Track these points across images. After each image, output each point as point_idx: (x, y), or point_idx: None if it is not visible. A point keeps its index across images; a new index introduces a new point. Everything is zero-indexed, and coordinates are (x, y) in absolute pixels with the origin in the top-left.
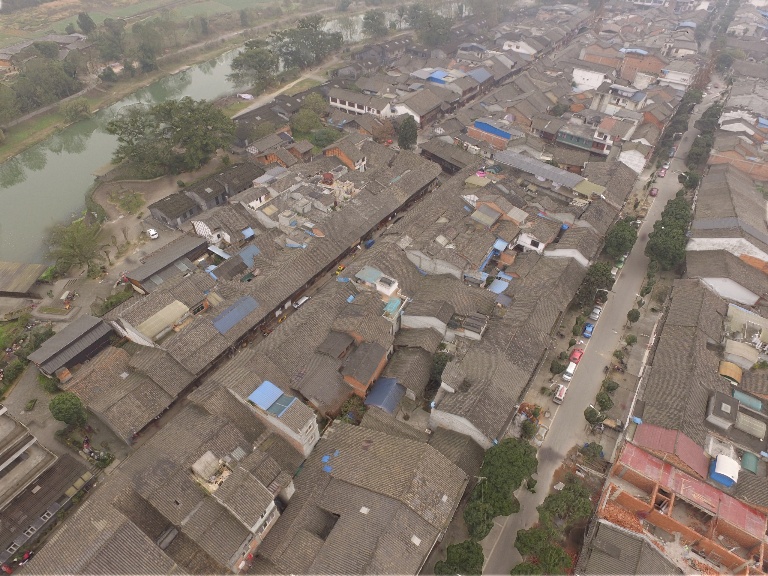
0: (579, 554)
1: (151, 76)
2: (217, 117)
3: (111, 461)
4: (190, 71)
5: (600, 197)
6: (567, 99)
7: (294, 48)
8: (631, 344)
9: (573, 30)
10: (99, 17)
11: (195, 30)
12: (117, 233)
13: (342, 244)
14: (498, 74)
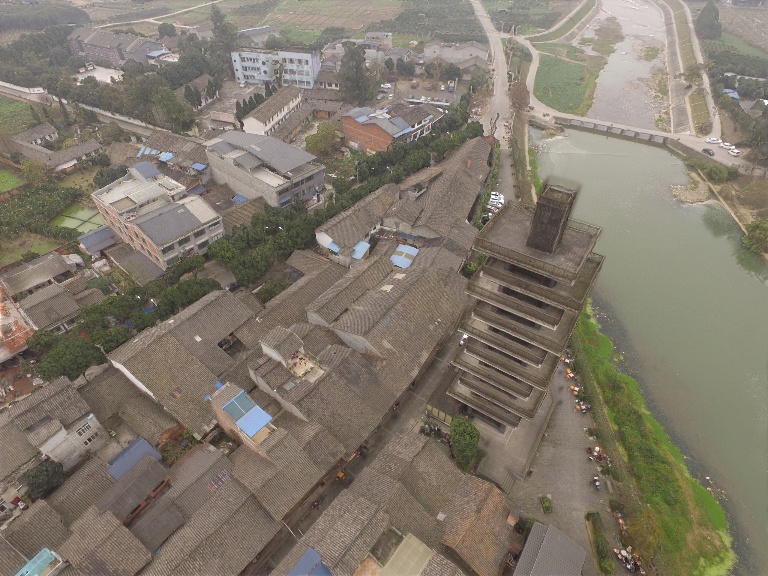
0: None
1: None
2: None
3: None
4: None
5: None
6: None
7: None
8: None
9: None
10: None
11: None
12: None
13: None
14: None
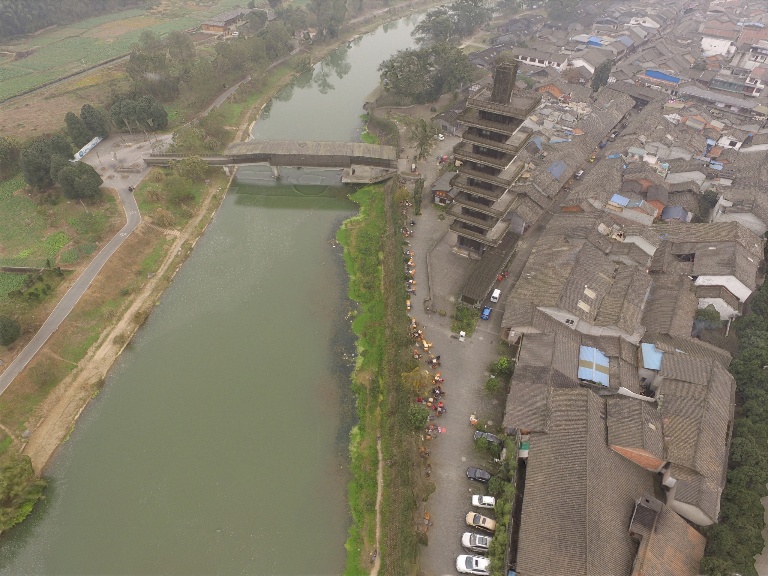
0: None
1: (335, 42)
2: None
3: None
4: None
5: None
6: (701, 61)
7: (457, 20)
8: None
9: (680, 11)
10: None
11: (354, 7)
12: None
13: (596, 139)
14: (636, 42)
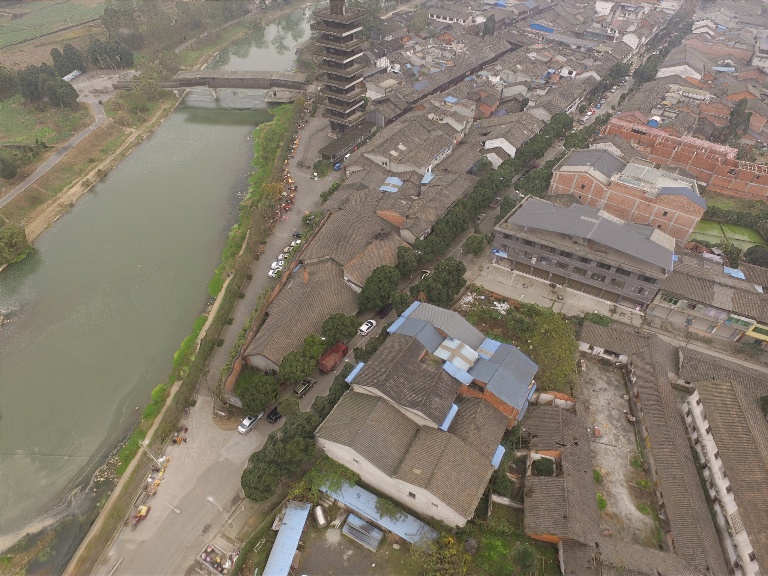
0: None
1: (289, 8)
2: (376, 11)
3: (379, 131)
4: None
5: (609, 52)
6: (591, 20)
7: None
8: (620, 104)
9: None
10: None
11: None
12: None
13: (463, 69)
14: (542, 6)
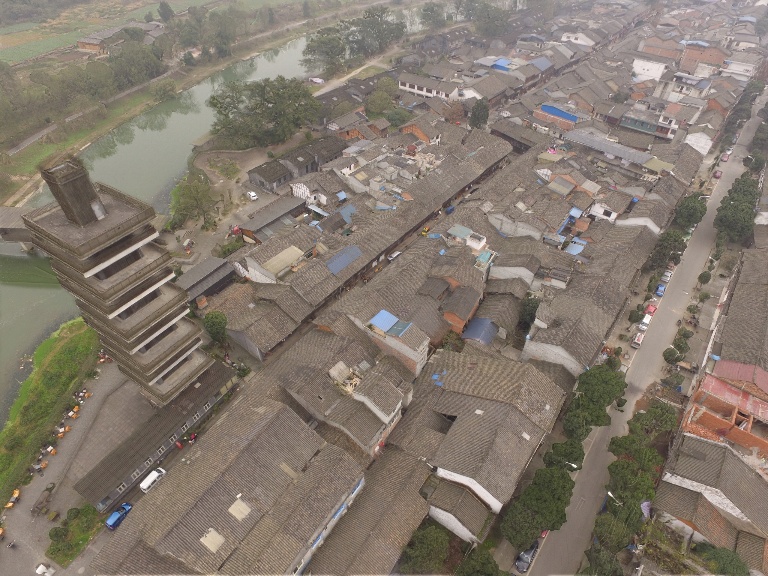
0: (665, 462)
1: (225, 61)
2: (307, 94)
3: (248, 372)
4: (256, 58)
5: (669, 173)
6: (627, 88)
7: (360, 37)
8: (704, 301)
9: (629, 24)
10: None
11: (263, 20)
12: None
13: (429, 207)
14: (558, 63)
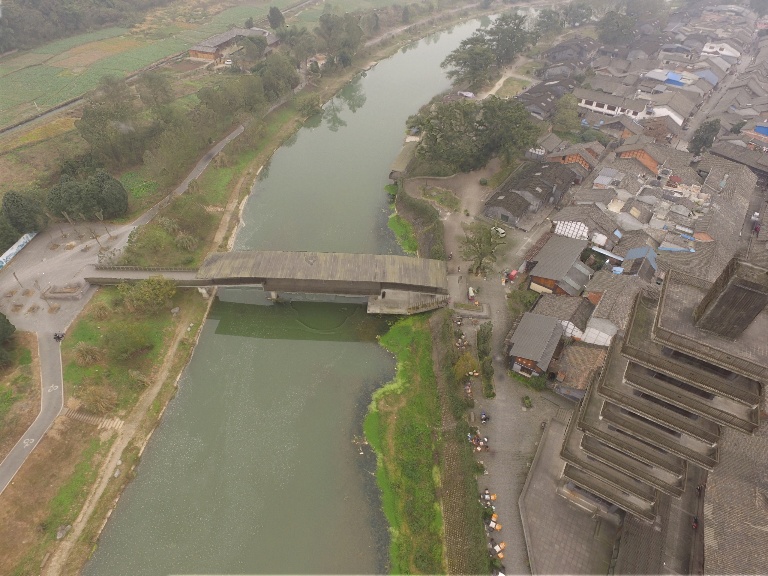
0: None
1: (348, 71)
2: None
3: None
4: None
5: None
6: None
7: (495, 46)
8: None
9: (753, 32)
10: (253, 11)
11: (370, 26)
12: (459, 230)
13: (730, 249)
14: None
